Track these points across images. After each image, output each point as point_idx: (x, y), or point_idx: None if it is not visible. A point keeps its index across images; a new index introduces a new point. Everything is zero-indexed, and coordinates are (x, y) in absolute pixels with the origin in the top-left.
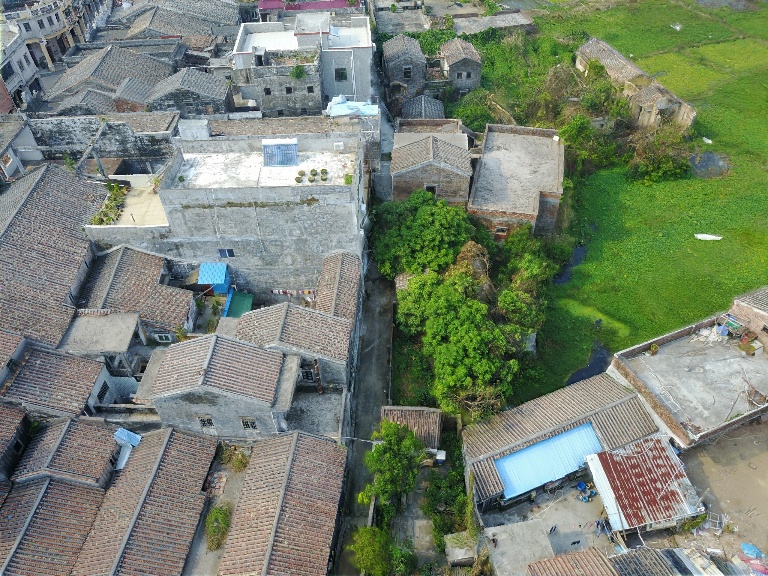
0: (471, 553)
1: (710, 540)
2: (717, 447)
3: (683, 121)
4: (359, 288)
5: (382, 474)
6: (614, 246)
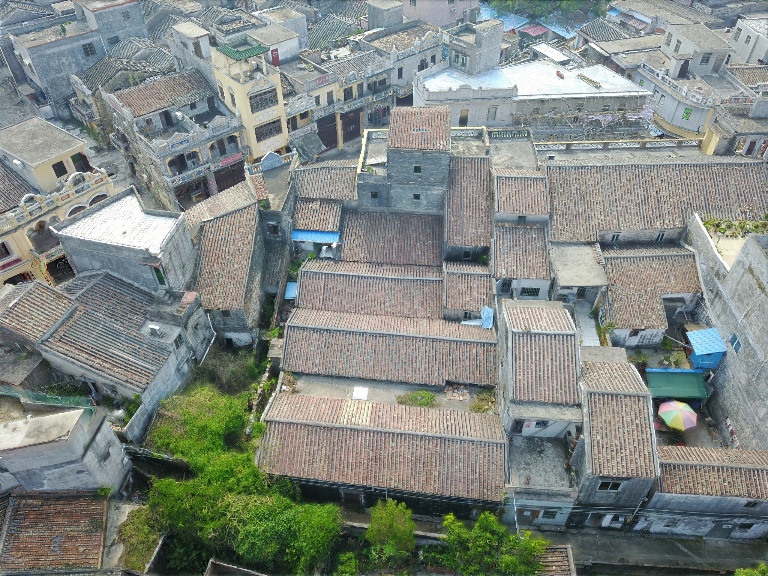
0: None
1: None
2: None
3: None
4: (762, 512)
5: None
6: None
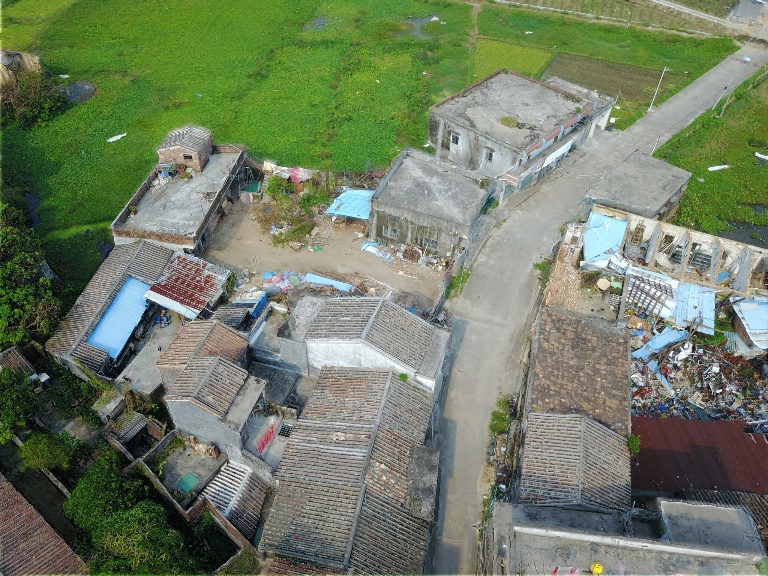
0: (118, 399)
1: (247, 287)
2: (215, 243)
3: (33, 68)
4: None
5: (4, 409)
6: (55, 178)
